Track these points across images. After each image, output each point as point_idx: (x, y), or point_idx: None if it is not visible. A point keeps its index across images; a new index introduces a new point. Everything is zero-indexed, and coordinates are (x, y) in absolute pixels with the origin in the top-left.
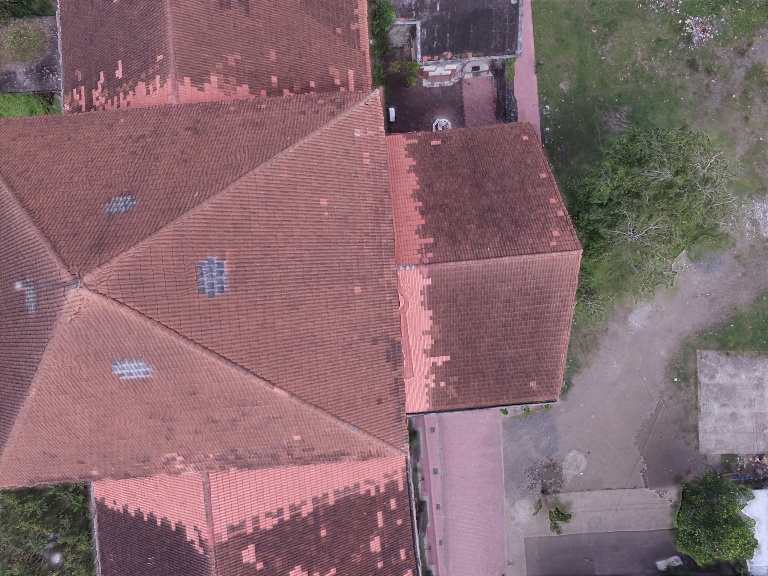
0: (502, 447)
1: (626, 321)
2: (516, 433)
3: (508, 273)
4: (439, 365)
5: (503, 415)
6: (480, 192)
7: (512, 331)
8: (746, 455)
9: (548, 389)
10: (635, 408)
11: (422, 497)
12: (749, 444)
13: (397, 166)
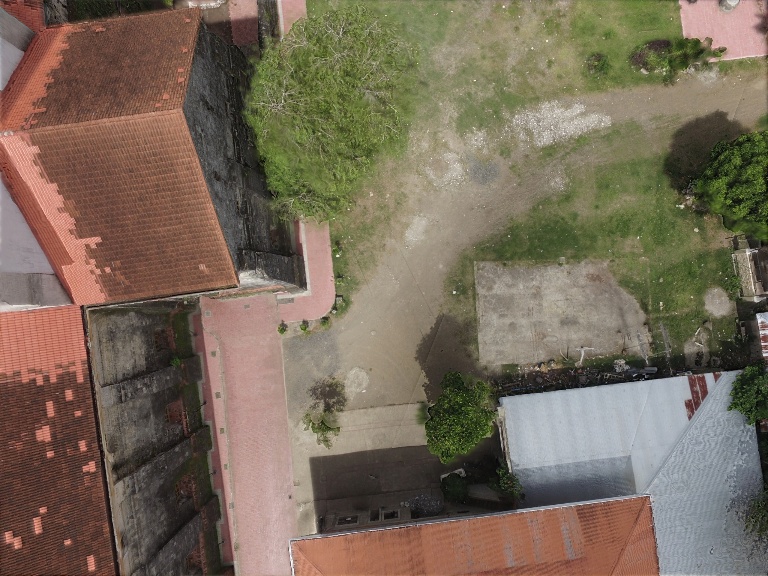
0: (284, 368)
1: (403, 236)
2: (297, 353)
3: (116, 138)
4: (94, 248)
5: (283, 336)
6: (115, 67)
7: (152, 206)
8: (527, 364)
9: (221, 273)
10: (415, 323)
11: (205, 422)
12: (529, 353)
13: (49, 51)
